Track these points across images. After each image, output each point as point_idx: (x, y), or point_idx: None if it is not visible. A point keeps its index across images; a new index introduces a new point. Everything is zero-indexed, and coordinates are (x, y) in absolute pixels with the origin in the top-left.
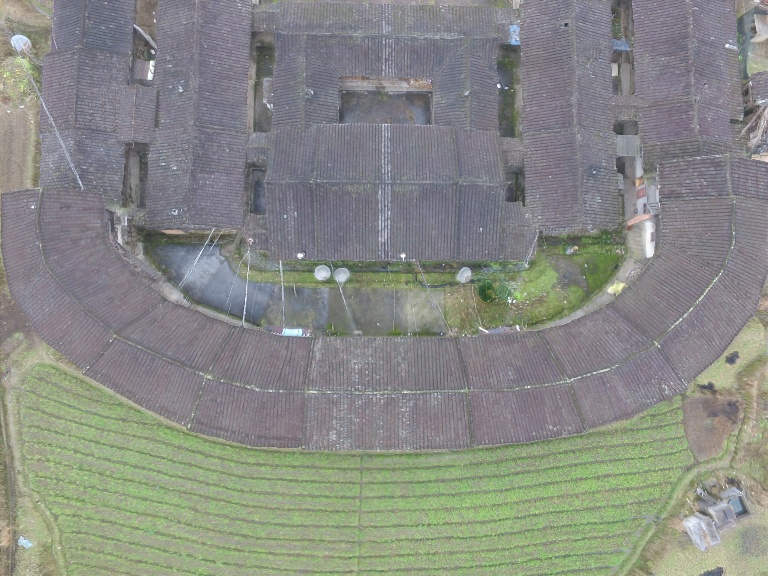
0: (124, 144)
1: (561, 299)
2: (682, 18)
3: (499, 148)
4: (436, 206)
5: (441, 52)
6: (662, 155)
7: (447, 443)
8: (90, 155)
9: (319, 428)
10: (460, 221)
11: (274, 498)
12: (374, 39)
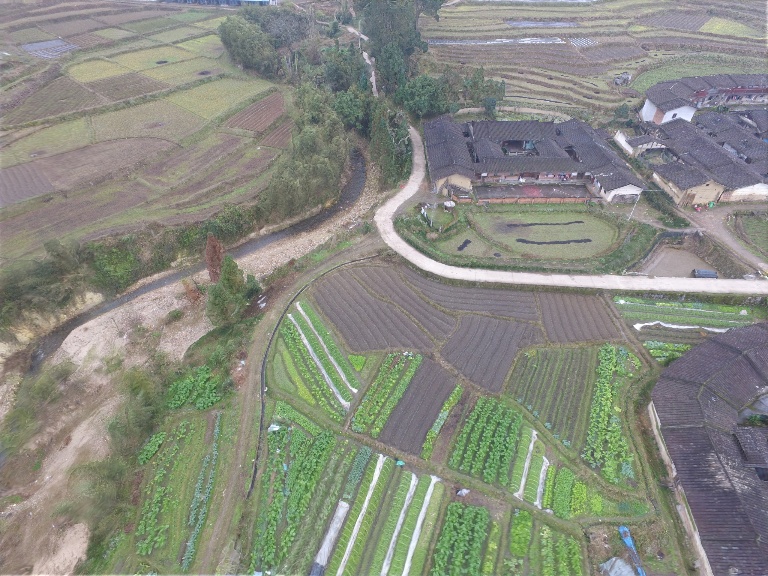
0: None
1: (694, 113)
2: (720, 149)
3: (759, 124)
4: None
5: None
6: (694, 125)
7: None
8: None
9: None
10: None
11: None
12: None
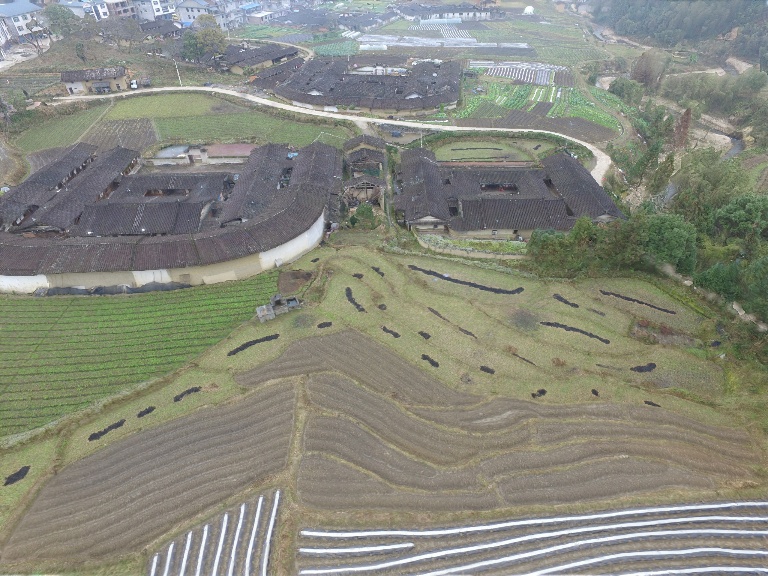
0: (27, 206)
1: None
2: None
3: None
4: (166, 211)
5: (197, 180)
6: None
7: (117, 267)
8: (7, 208)
9: (48, 262)
10: (178, 217)
11: (4, 319)
12: (167, 177)
